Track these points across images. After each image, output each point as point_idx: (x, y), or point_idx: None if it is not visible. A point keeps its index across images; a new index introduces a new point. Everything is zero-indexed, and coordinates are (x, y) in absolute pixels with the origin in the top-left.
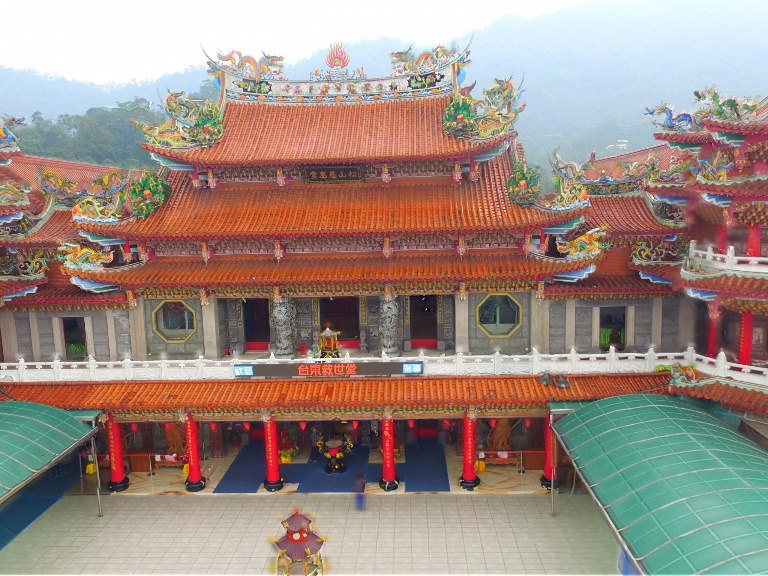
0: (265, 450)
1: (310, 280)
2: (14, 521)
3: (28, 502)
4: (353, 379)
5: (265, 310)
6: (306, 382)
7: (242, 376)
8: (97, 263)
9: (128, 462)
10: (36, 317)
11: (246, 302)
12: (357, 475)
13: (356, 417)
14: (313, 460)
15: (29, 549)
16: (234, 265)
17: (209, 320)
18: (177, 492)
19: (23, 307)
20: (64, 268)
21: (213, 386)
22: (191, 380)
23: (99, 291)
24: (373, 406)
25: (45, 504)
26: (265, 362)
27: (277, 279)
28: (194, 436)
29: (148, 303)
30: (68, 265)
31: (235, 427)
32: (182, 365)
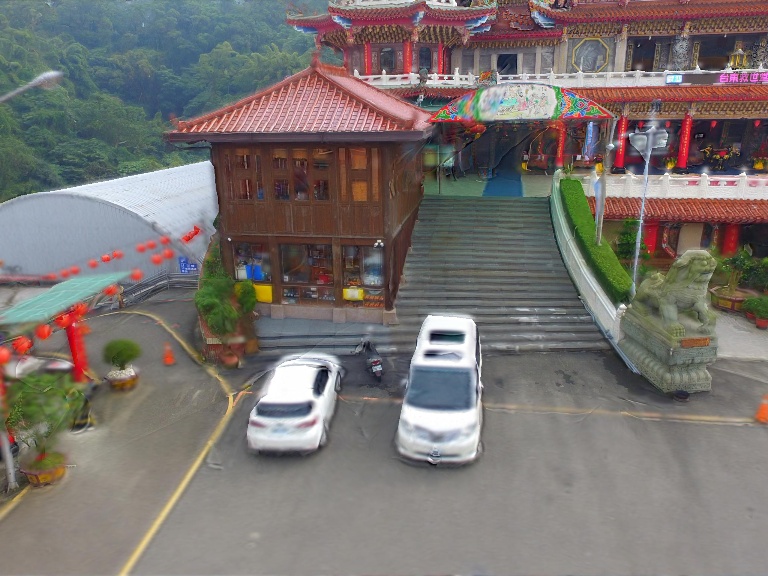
0: (642, 166)
1: (725, 12)
2: (511, 177)
3: (512, 169)
4: (765, 85)
5: (651, 55)
6: (725, 87)
7: (672, 83)
8: (547, 3)
9: (551, 162)
10: (479, 54)
11: (639, 46)
12: (740, 172)
13: (761, 116)
14: (693, 167)
15: (542, 184)
16: (649, 7)
17: (621, 54)
18: (607, 174)
19: (475, 44)
20: (531, 3)
21: (650, 90)
22: None
23: (545, 26)
24: None
25: (518, 174)
26: (692, 72)
27: (697, 12)
28: None
29: (571, 41)
30: (534, 1)
31: (616, 150)
32: (623, 76)
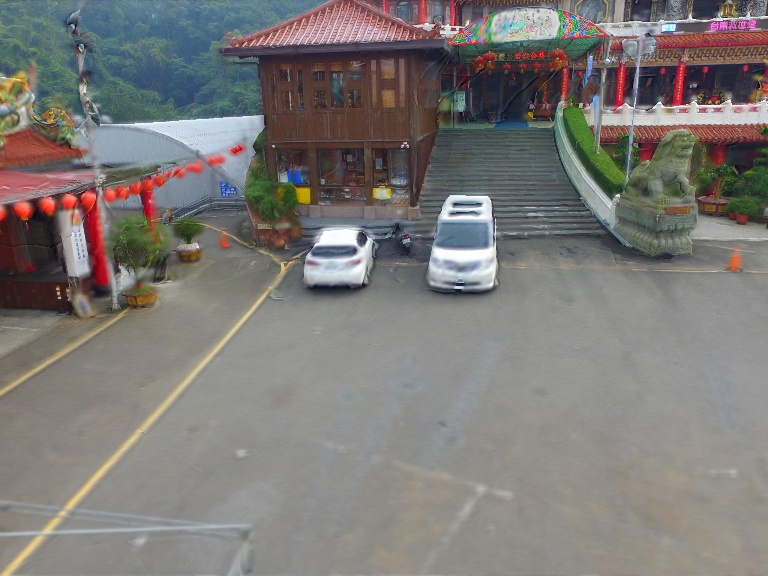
0: None
1: None
2: (518, 120)
3: (519, 114)
4: (752, 31)
5: (648, 11)
6: (716, 34)
7: (667, 32)
8: None
9: None
10: (488, 12)
11: (637, 3)
12: None
13: (749, 61)
14: None
15: None
16: None
17: (620, 9)
18: None
19: (484, 1)
20: None
21: None
22: (629, 36)
23: None
24: (767, 49)
25: None
26: (685, 21)
27: None
28: (623, 79)
29: None
30: None
31: None
32: (622, 26)
